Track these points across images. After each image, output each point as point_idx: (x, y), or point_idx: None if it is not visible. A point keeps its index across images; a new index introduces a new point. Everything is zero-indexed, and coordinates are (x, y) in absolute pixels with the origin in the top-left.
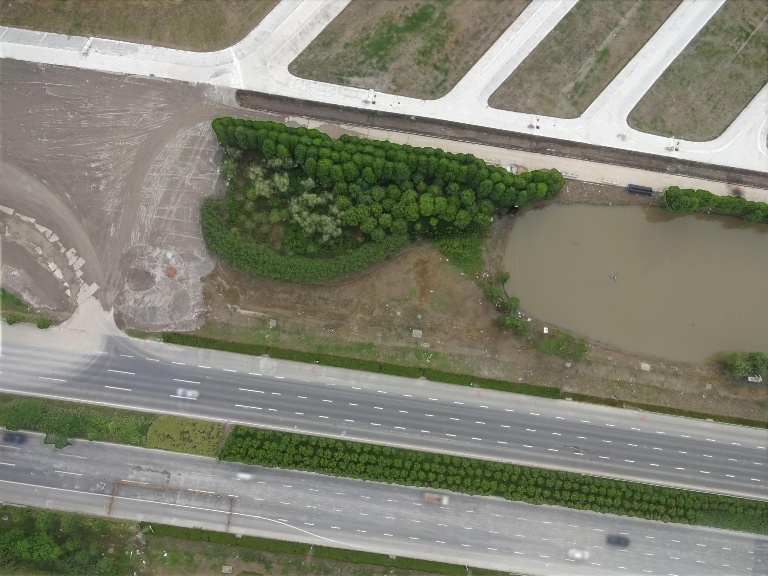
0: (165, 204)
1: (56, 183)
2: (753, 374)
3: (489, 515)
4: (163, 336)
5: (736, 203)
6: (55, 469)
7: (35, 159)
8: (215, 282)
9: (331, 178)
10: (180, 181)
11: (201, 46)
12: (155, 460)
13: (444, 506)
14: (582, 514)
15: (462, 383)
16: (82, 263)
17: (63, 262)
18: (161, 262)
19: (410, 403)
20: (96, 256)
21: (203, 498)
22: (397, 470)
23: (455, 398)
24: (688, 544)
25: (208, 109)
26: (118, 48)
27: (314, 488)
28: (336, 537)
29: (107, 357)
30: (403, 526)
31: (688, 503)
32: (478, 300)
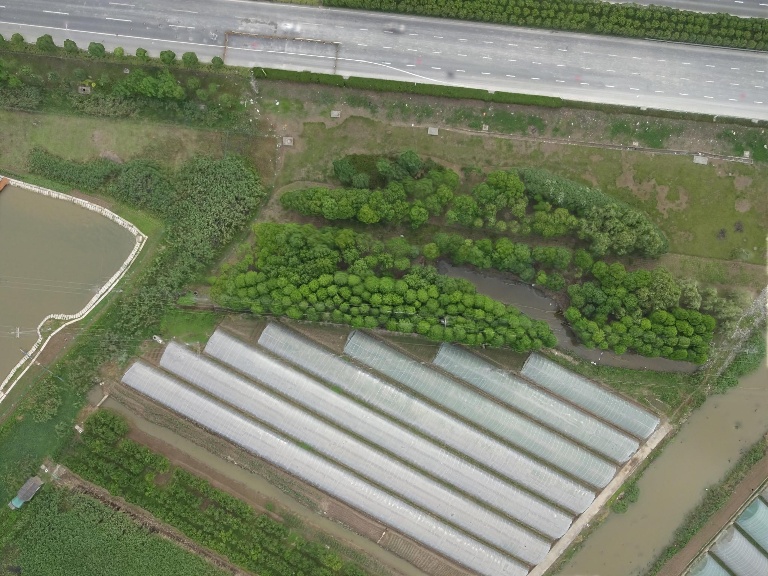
0: None
1: None
2: None
3: (581, 53)
4: None
5: None
6: (169, 24)
7: None
8: None
9: None
10: None
11: None
12: (262, 12)
13: (538, 46)
14: (670, 49)
15: None
16: None
17: None
18: None
19: None
20: None
21: (310, 46)
22: (493, 5)
23: None
24: None
25: None
26: None
27: (414, 33)
28: (437, 77)
29: None
30: (500, 65)
31: None
32: None
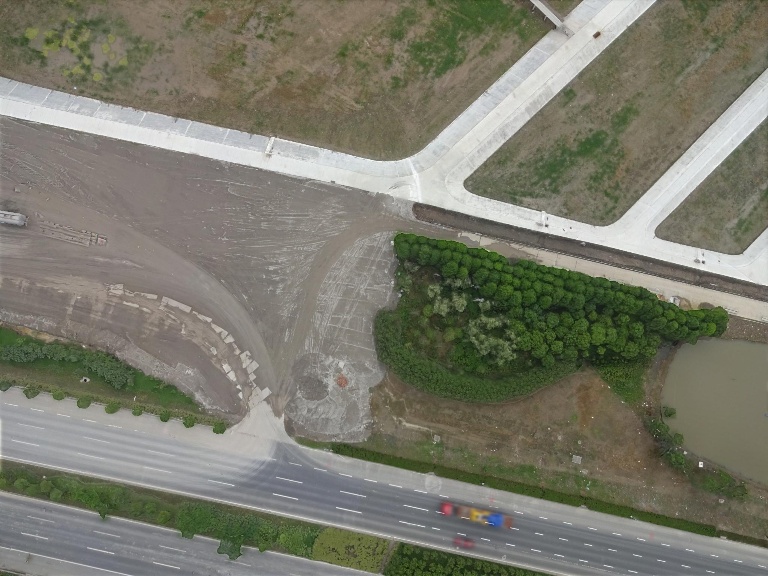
0: (340, 313)
1: (234, 284)
2: None
3: None
4: (332, 447)
5: None
6: (219, 575)
7: (214, 258)
8: (382, 393)
9: (509, 303)
10: (355, 290)
11: (379, 154)
12: (318, 572)
13: None
14: None
15: (622, 515)
16: (256, 367)
17: (237, 364)
18: (333, 371)
19: (570, 531)
20: (270, 360)
21: None
22: None
23: (614, 529)
24: None
25: (386, 220)
26: (300, 151)
27: None
28: None
29: (276, 464)
30: None
31: None
32: (637, 430)
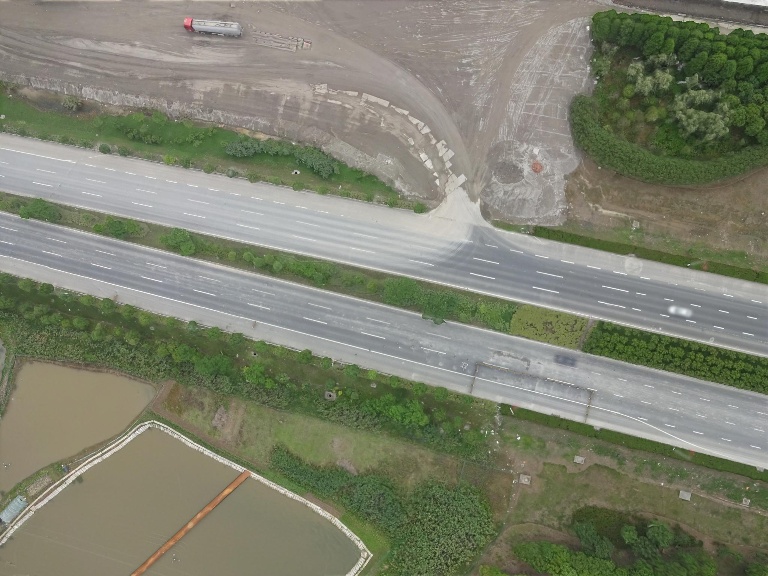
0: (534, 100)
1: (429, 78)
2: None
3: None
4: (529, 229)
5: None
6: (421, 346)
7: (410, 54)
8: (577, 180)
9: (720, 75)
10: (549, 78)
11: None
12: (516, 347)
13: None
14: None
15: None
16: (451, 155)
17: (433, 153)
18: (528, 157)
19: None
20: (465, 149)
21: (562, 388)
22: None
23: None
24: None
25: (580, 6)
26: None
27: (677, 391)
28: (698, 442)
29: (473, 246)
30: None
31: None
32: None
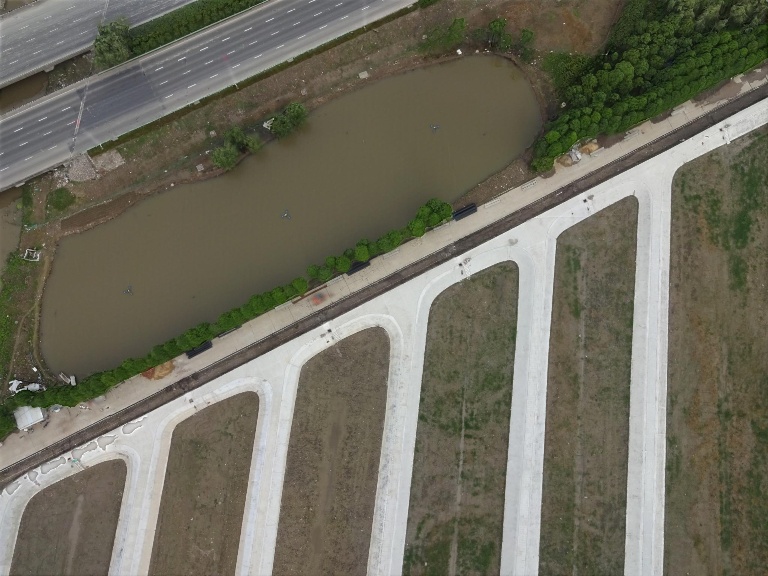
0: None
1: None
2: None
3: None
4: None
5: (389, 237)
6: None
7: None
8: None
9: None
10: None
11: None
12: None
13: None
14: None
15: None
16: None
17: None
18: None
19: None
20: None
21: None
22: None
23: None
24: None
25: None
26: None
27: None
28: None
29: None
30: None
31: None
32: None
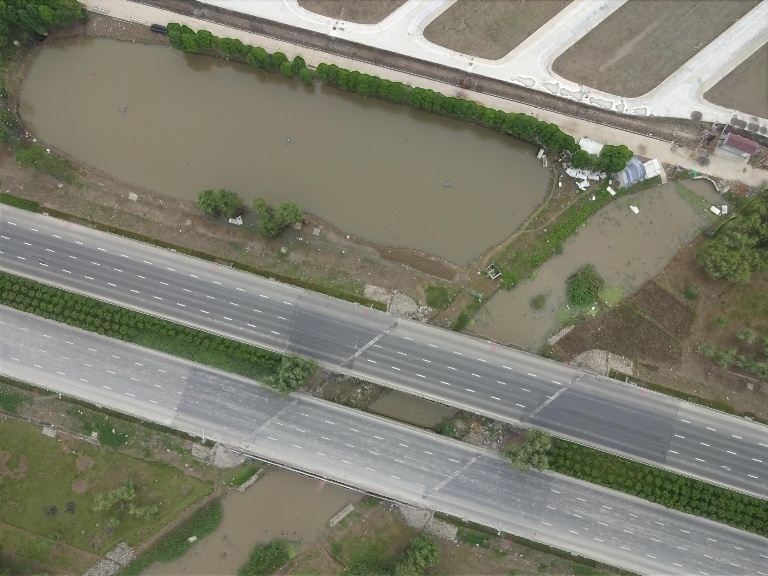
0: None
1: None
2: (234, 216)
3: None
4: None
5: (229, 44)
6: None
7: None
8: None
9: None
10: None
11: None
12: None
13: None
14: (35, 319)
15: None
16: None
17: None
18: None
19: None
20: None
21: None
22: None
23: None
24: (127, 361)
25: None
26: None
27: None
28: None
29: None
30: None
31: (123, 319)
32: None
